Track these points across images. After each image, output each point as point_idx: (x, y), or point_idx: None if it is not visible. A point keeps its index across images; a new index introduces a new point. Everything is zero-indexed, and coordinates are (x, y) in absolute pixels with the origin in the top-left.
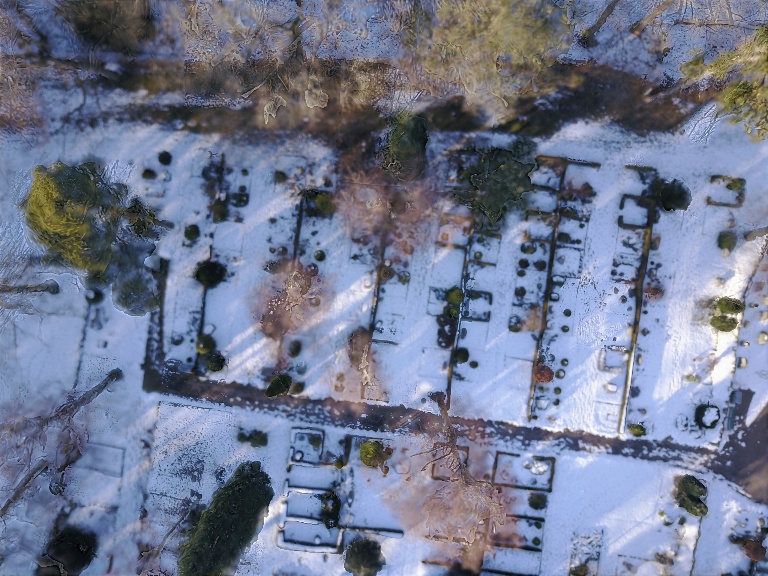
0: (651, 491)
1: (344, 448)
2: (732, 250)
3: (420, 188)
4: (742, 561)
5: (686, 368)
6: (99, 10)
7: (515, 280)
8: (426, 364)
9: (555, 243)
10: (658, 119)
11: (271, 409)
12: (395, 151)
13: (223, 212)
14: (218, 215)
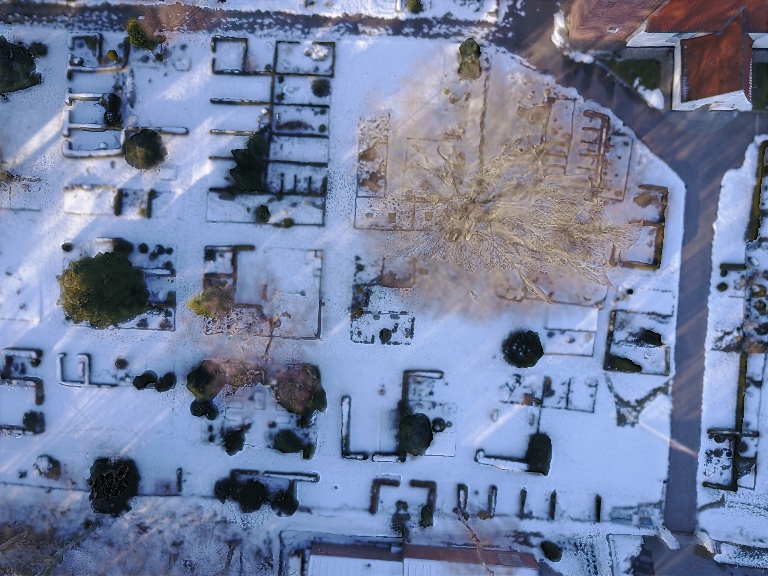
0: (435, 70)
1: (123, 51)
2: None
3: None
4: (532, 135)
5: None
6: None
7: None
8: None
9: None
10: None
11: (49, 21)
12: None
13: None
14: None
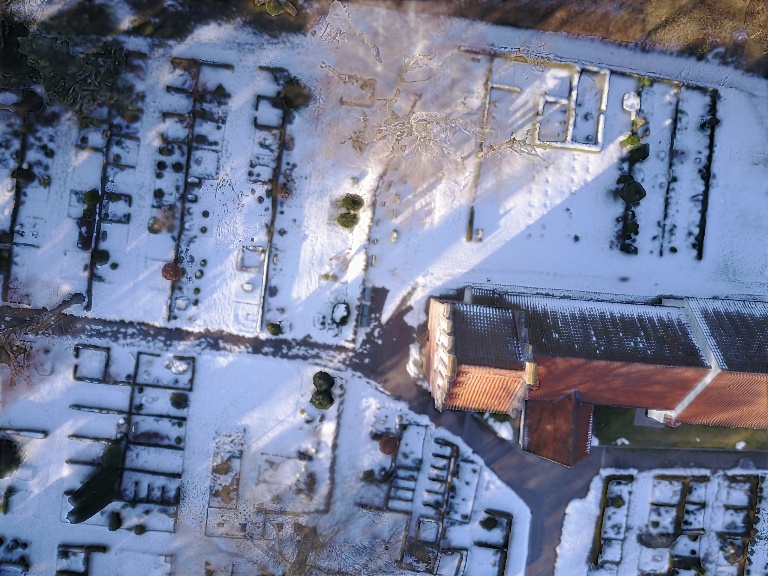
0: (291, 390)
1: None
2: (365, 150)
3: None
4: (383, 458)
5: (323, 267)
6: None
7: (154, 182)
8: (68, 267)
9: (191, 145)
10: (287, 20)
11: None
12: None
13: None
14: None
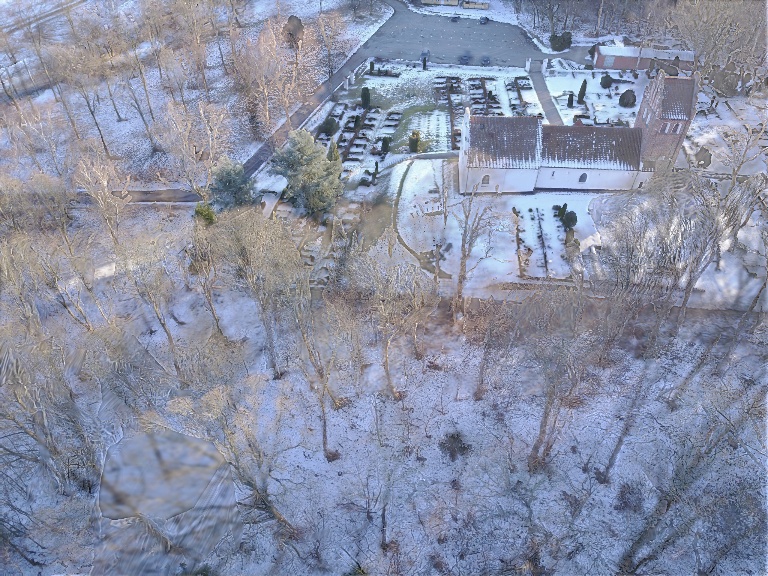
0: None
1: None
2: None
3: None
4: None
5: None
6: None
7: None
8: None
9: None
10: None
11: None
12: None
13: None
14: None
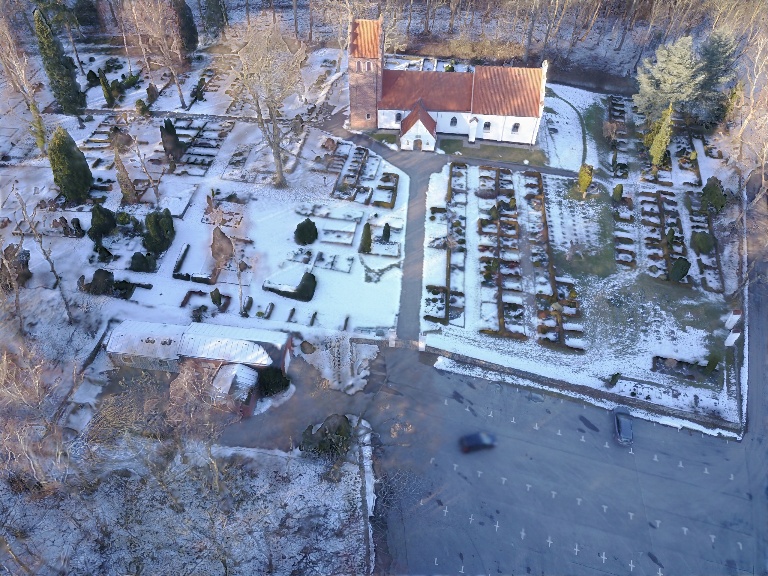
0: None
1: None
2: (329, 75)
3: (198, 65)
4: None
5: None
6: (86, 4)
7: None
8: None
9: None
10: None
11: (101, 114)
12: (175, 9)
13: (109, 69)
14: (107, 68)
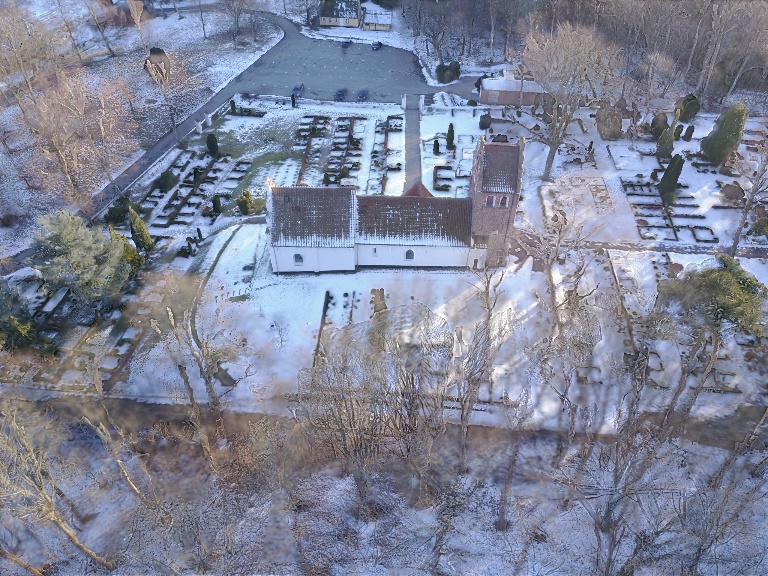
0: None
1: None
2: None
3: None
4: None
5: None
6: None
7: None
8: None
9: None
10: None
11: None
12: None
13: None
14: None
